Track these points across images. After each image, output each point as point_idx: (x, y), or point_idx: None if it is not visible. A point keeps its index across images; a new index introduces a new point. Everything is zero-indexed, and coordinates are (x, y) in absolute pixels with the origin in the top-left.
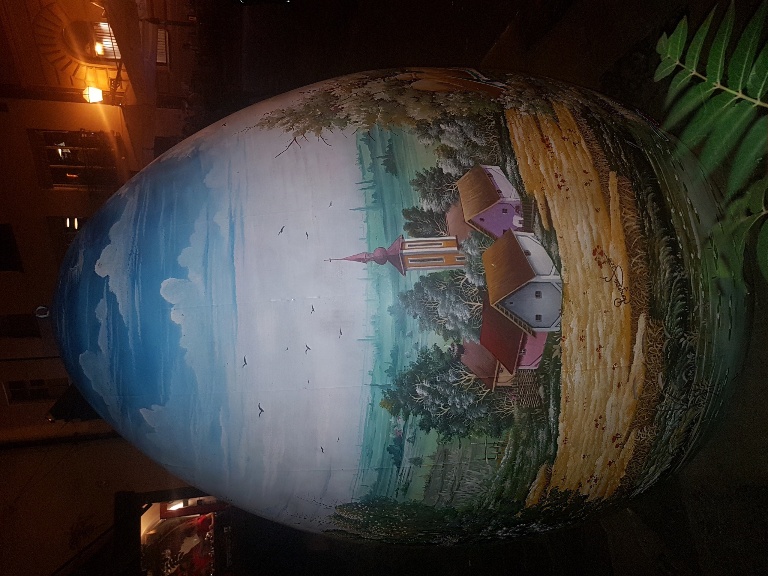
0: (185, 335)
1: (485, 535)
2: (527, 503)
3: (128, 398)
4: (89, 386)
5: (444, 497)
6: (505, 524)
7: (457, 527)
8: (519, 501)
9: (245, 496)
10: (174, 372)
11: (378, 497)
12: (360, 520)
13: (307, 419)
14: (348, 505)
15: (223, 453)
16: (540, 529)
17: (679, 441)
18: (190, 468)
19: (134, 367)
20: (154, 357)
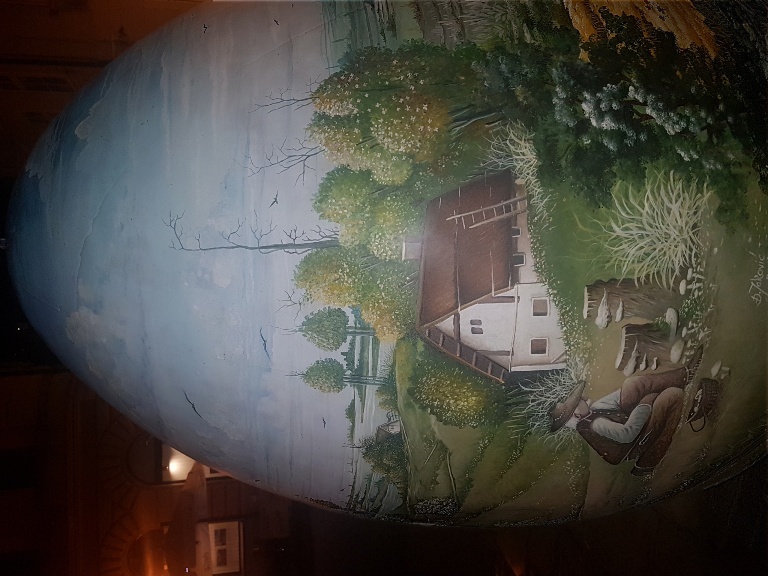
0: (138, 43)
1: (570, 125)
2: (580, 32)
3: (65, 134)
4: (26, 185)
5: (450, 28)
6: (579, 82)
7: (505, 93)
8: (565, 28)
9: (193, 171)
10: (120, 65)
11: (362, 52)
12: (354, 114)
13: (256, 8)
14: (327, 84)
15: (162, 97)
16: (659, 119)
17: (751, 6)
18: (122, 174)
19: (80, 97)
20: (103, 71)
